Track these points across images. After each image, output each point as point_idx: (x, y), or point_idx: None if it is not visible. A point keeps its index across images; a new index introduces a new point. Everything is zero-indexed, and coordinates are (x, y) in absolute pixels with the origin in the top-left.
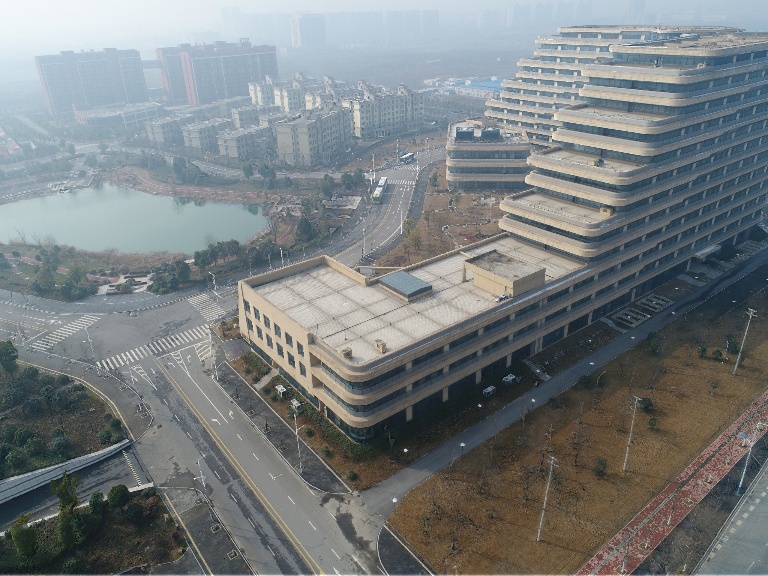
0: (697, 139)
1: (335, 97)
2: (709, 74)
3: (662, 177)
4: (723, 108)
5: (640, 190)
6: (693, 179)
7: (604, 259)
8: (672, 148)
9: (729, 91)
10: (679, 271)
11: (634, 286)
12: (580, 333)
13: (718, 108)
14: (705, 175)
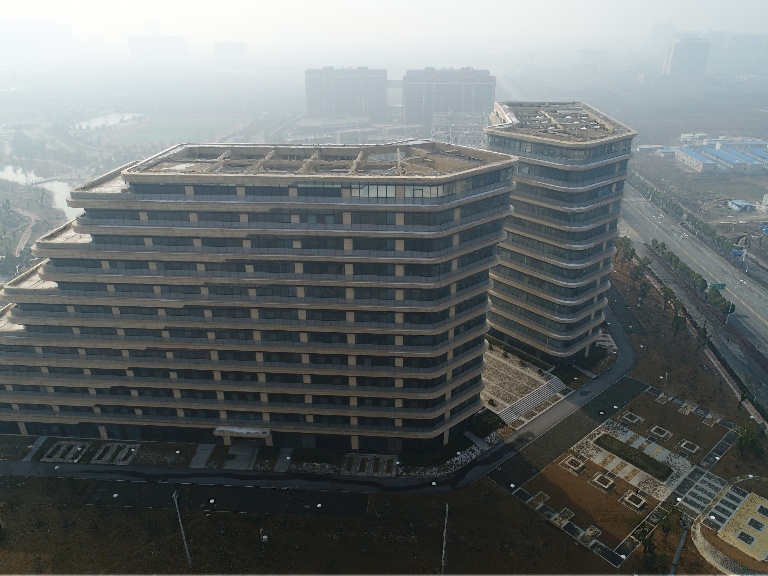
0: (136, 279)
1: None
2: (116, 202)
3: (88, 310)
4: (197, 251)
5: (44, 314)
6: (157, 328)
7: (13, 372)
8: (79, 279)
9: (187, 231)
10: (206, 438)
11: (88, 421)
12: (2, 437)
13: (182, 249)
14: (202, 330)
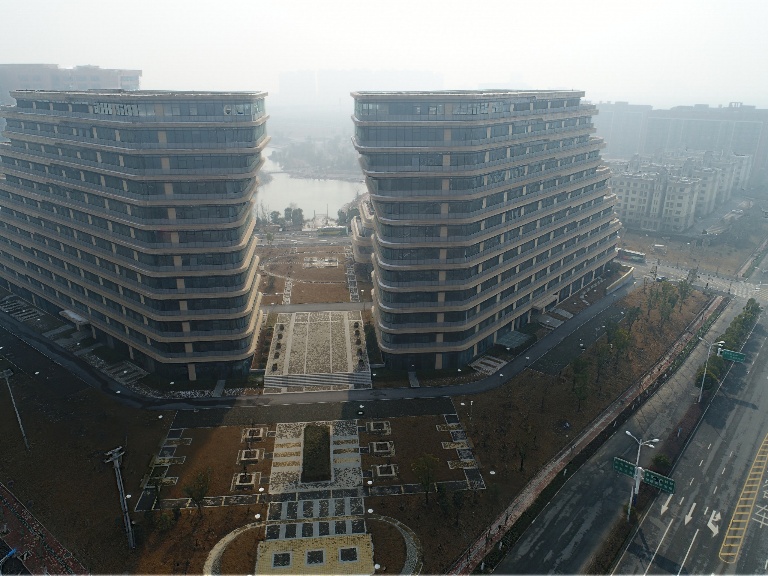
0: None
1: (630, 170)
2: None
3: (16, 198)
4: None
5: None
6: (36, 217)
7: None
8: (7, 172)
9: None
10: None
11: None
12: (1, 289)
13: (38, 153)
14: None
